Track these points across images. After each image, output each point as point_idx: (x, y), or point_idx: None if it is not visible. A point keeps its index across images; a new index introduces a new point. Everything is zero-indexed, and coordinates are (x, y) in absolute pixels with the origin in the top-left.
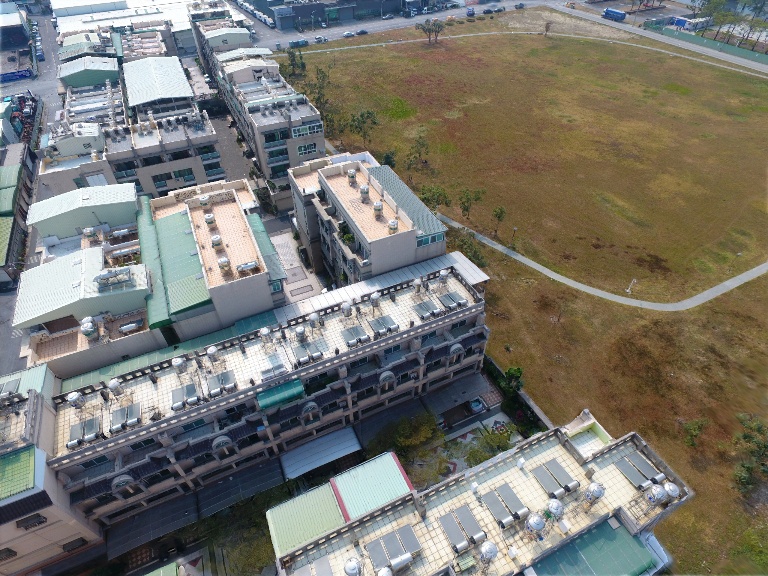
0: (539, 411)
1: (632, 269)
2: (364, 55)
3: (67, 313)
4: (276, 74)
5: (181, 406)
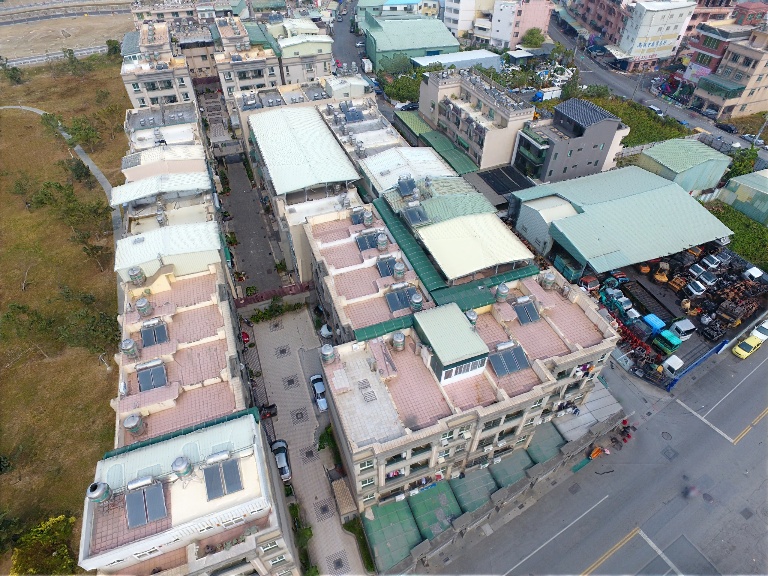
0: None
1: (0, 121)
2: None
3: None
4: None
5: None
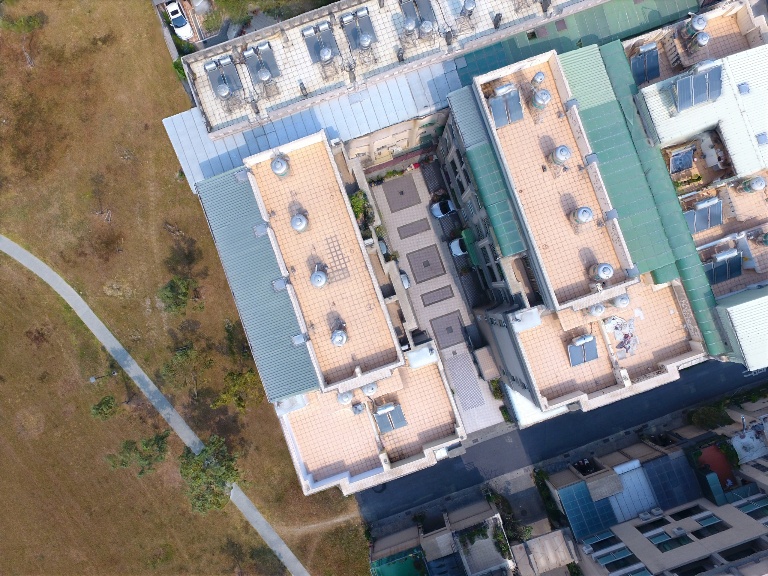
0: (173, 52)
1: None
2: None
3: None
4: None
5: None
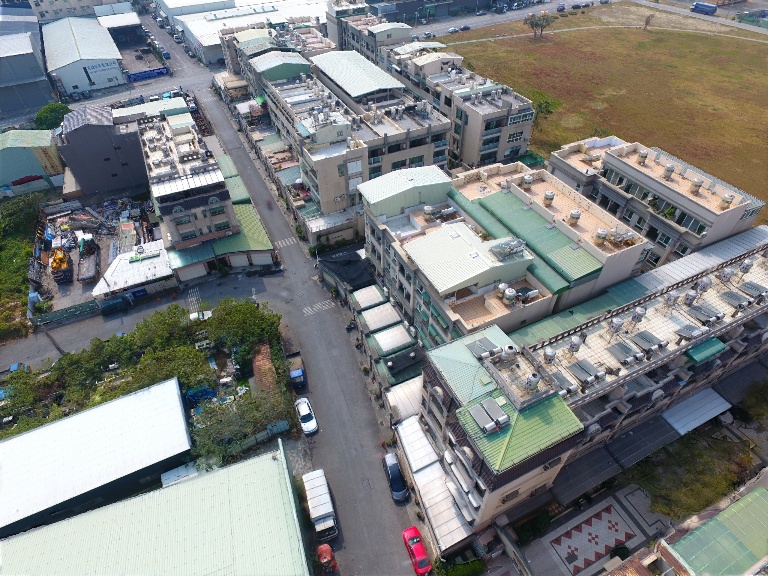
0: None
1: None
2: (478, 50)
3: (476, 281)
4: (459, 66)
5: (633, 361)
